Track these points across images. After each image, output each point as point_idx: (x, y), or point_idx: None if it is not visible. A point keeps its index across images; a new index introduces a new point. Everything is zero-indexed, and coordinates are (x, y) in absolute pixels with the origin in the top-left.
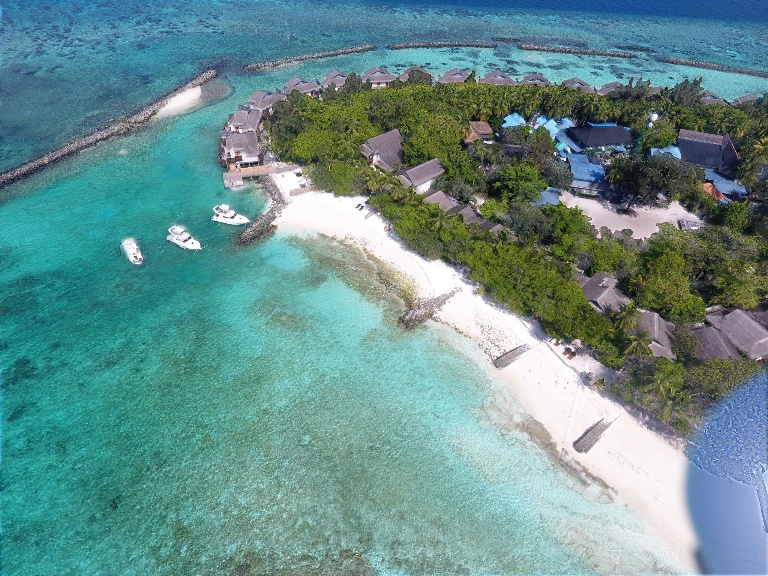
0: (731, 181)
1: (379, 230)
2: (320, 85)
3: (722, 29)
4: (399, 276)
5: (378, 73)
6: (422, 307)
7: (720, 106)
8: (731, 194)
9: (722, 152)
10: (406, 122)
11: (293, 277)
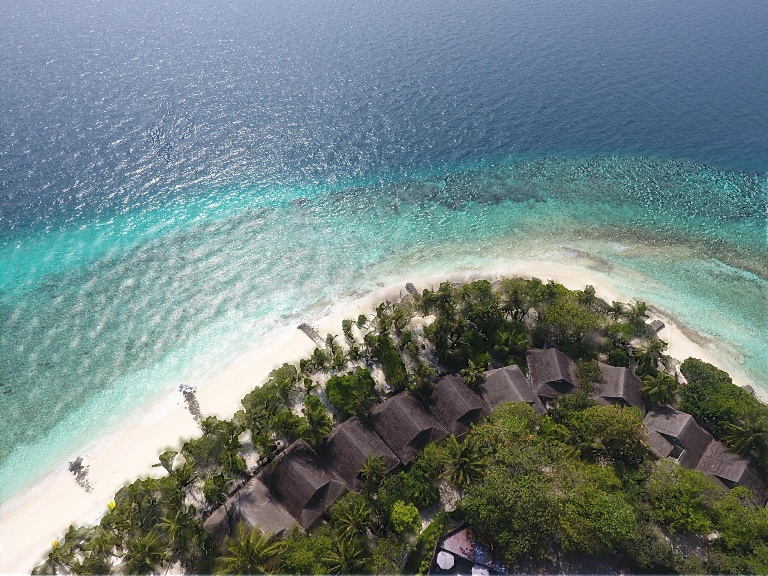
0: None
1: None
2: None
3: None
4: None
5: None
6: None
7: None
8: None
9: None
10: None
11: None
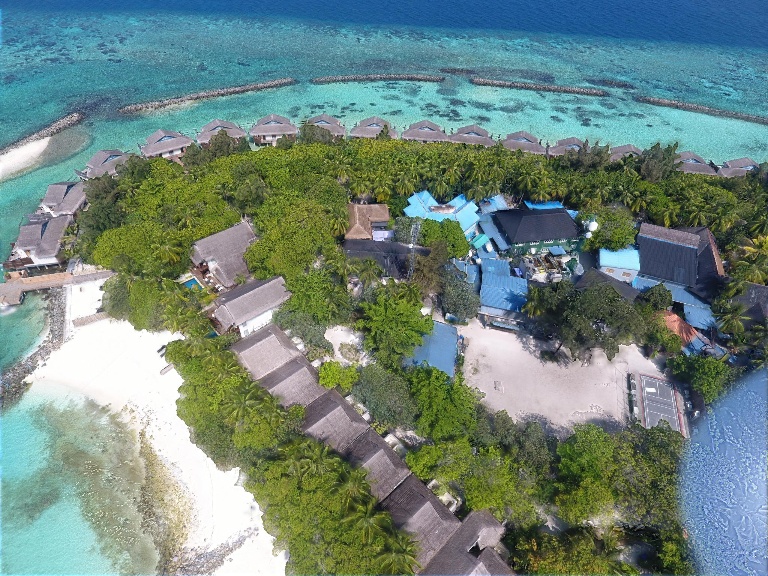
0: (709, 306)
1: (175, 396)
2: (194, 139)
3: (718, 57)
4: (173, 494)
5: (273, 123)
6: (179, 575)
7: (702, 179)
8: (707, 329)
9: (698, 259)
10: (260, 212)
11: (6, 495)
